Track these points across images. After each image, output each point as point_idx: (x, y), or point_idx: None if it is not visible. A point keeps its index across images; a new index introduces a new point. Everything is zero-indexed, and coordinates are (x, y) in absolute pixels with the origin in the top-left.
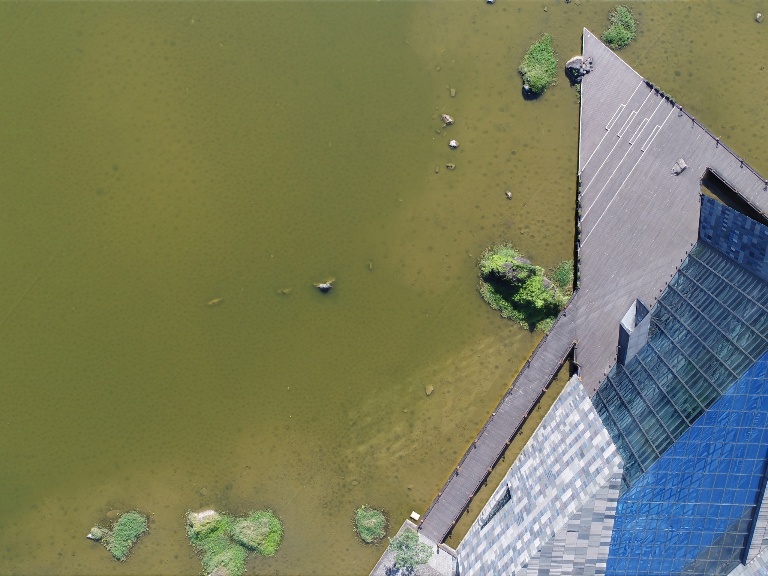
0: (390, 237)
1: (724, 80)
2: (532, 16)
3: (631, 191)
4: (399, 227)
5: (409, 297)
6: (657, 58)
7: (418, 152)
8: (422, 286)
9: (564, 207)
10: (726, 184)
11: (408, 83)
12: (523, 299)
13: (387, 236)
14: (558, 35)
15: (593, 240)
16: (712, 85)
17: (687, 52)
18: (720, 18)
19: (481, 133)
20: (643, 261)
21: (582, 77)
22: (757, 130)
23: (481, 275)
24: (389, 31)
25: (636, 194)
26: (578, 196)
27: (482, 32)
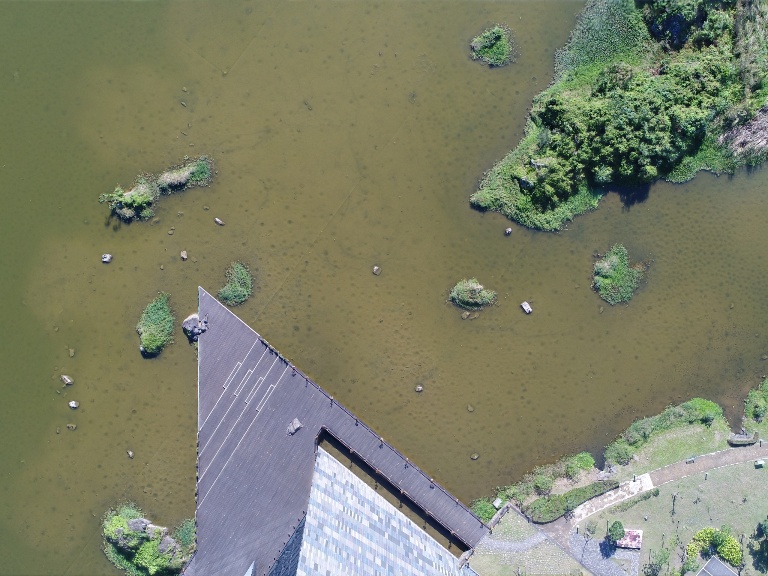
0: (13, 498)
1: (343, 334)
2: (149, 274)
3: (246, 452)
4: (22, 488)
5: (34, 558)
6: (275, 313)
7: (39, 413)
8: (47, 547)
9: (186, 465)
10: (342, 442)
11: (27, 344)
12: (140, 563)
13: (11, 497)
14: (175, 293)
15: (210, 502)
16: (332, 339)
17: (305, 307)
18: (338, 272)
19: (101, 393)
20: (260, 521)
21: (198, 336)
22: (378, 383)
23: (104, 535)
24: (6, 293)
25: (251, 455)
26: (197, 456)
27: (99, 292)
